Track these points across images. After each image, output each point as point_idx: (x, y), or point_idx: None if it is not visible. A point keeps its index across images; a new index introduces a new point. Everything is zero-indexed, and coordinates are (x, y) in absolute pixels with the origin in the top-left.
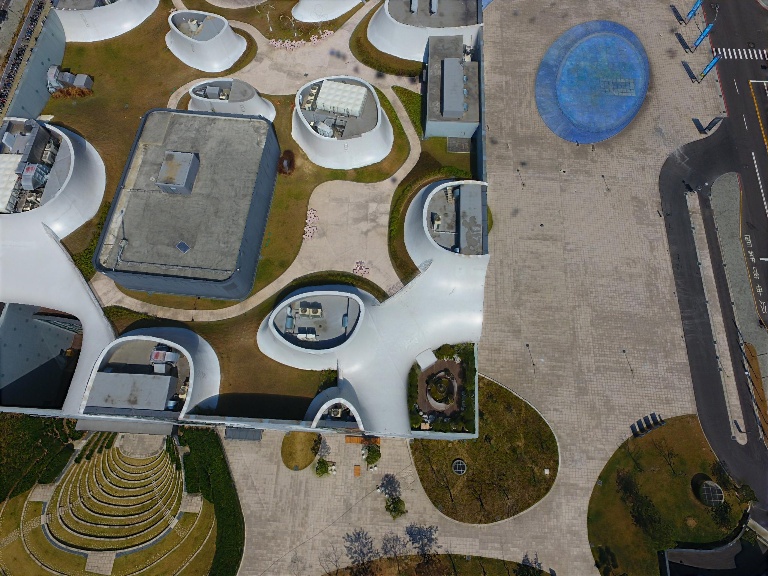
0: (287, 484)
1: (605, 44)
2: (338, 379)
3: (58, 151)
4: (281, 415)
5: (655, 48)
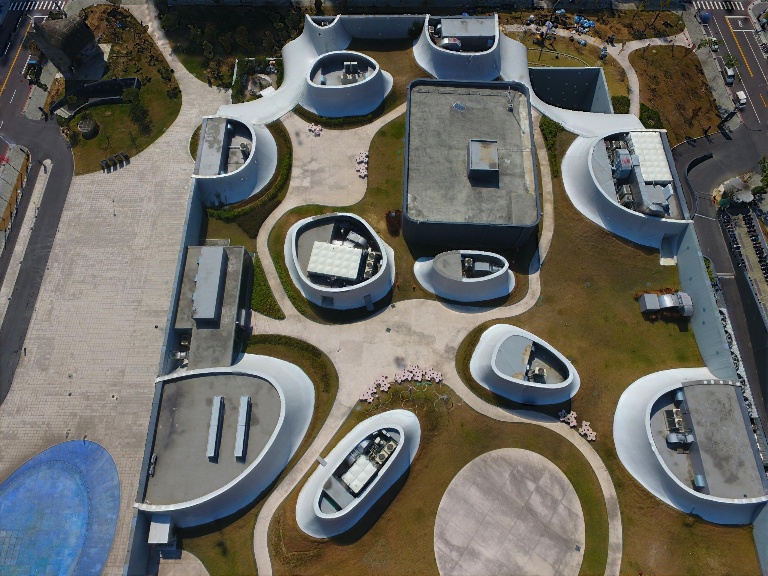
0: None
1: None
2: None
3: None
4: (368, 42)
5: None
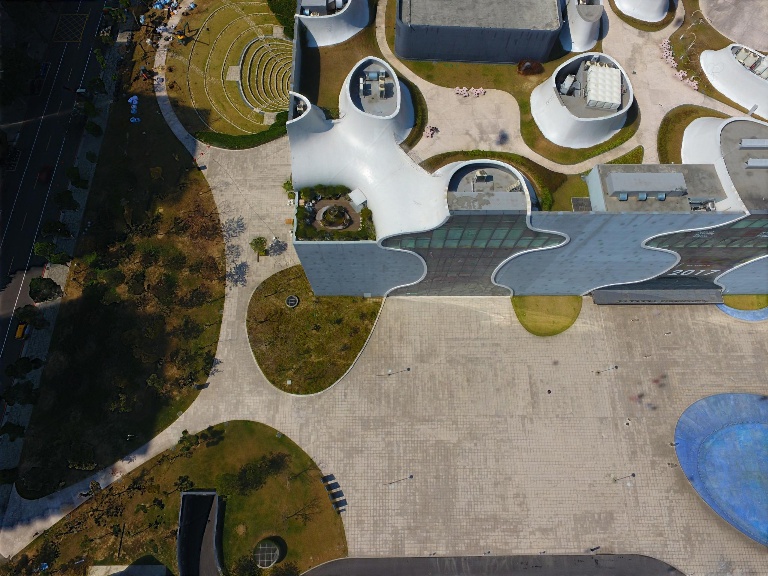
0: (280, 172)
1: None
2: (332, 119)
3: None
4: (304, 88)
5: None
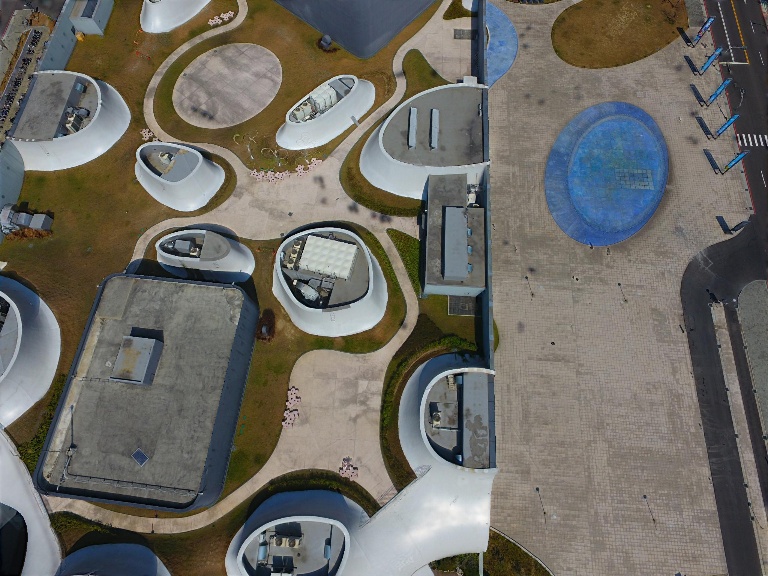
0: None
1: (620, 129)
2: None
3: (4, 323)
4: None
5: (674, 134)
